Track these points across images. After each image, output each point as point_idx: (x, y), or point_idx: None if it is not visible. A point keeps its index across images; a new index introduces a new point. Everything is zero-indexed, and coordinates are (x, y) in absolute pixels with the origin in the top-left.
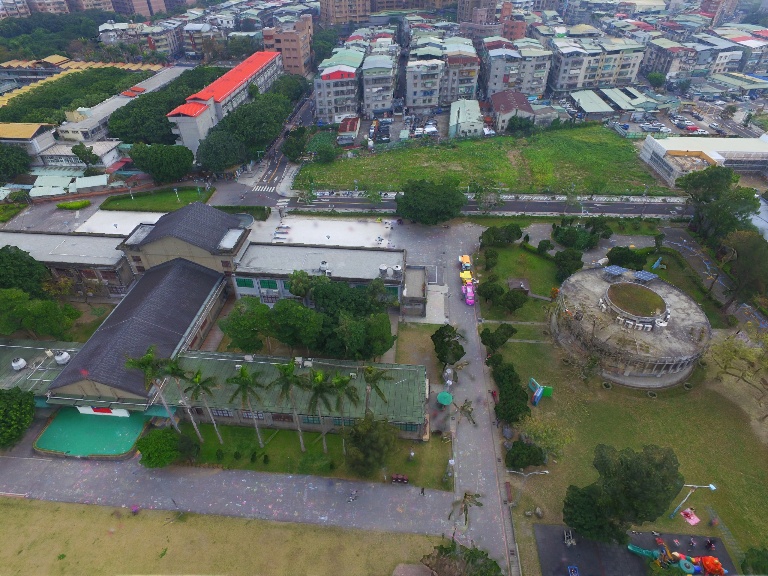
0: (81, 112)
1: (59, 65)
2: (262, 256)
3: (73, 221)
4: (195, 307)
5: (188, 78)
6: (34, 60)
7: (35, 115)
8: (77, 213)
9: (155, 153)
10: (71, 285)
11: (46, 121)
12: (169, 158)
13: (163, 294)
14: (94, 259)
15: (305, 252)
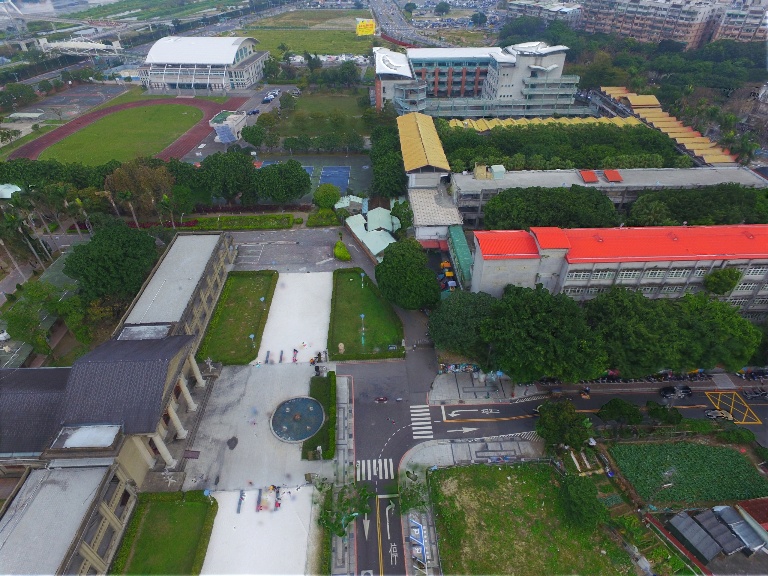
0: (493, 170)
1: (635, 108)
2: (65, 497)
3: (309, 264)
4: (5, 446)
5: (696, 196)
6: (635, 93)
7: (465, 152)
8: (327, 260)
9: (384, 264)
10: (101, 317)
11: (455, 162)
12: (389, 281)
13: (23, 403)
14: (141, 314)
15: (43, 574)
